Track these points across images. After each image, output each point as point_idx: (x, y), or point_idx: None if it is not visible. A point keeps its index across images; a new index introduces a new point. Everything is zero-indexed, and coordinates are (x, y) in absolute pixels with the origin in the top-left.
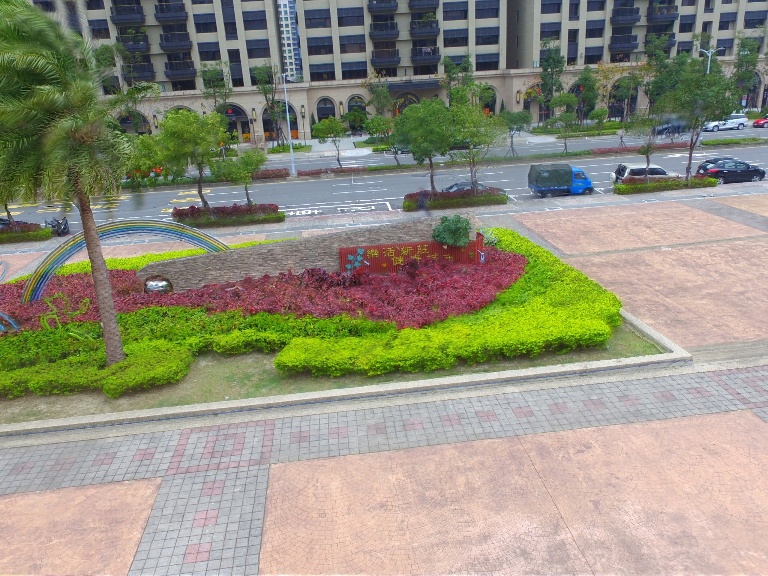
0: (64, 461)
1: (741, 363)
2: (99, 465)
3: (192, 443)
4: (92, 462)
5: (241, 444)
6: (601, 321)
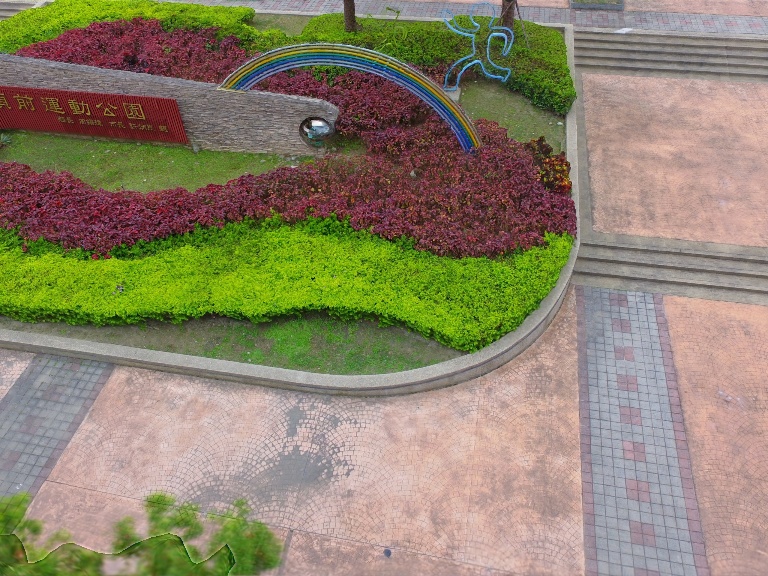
0: (374, 8)
1: (26, 1)
2: (357, 5)
3: (313, 6)
4: (361, 6)
5: (291, 3)
6: (56, 1)
